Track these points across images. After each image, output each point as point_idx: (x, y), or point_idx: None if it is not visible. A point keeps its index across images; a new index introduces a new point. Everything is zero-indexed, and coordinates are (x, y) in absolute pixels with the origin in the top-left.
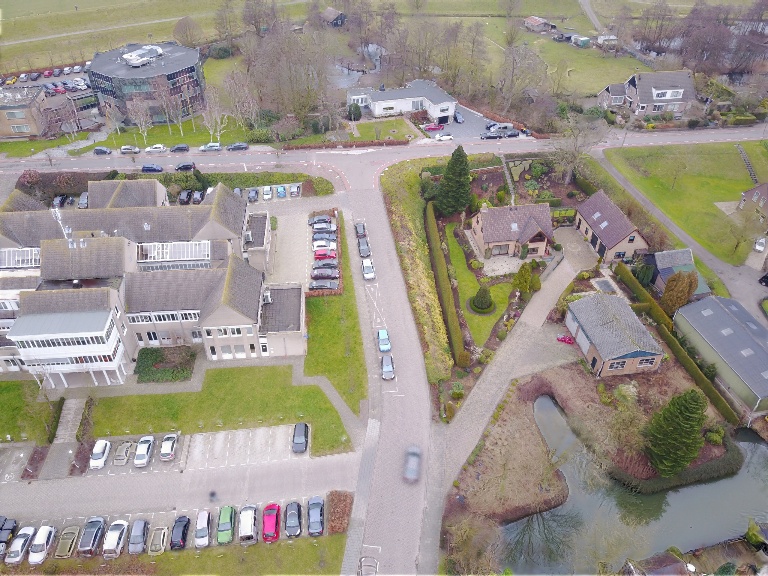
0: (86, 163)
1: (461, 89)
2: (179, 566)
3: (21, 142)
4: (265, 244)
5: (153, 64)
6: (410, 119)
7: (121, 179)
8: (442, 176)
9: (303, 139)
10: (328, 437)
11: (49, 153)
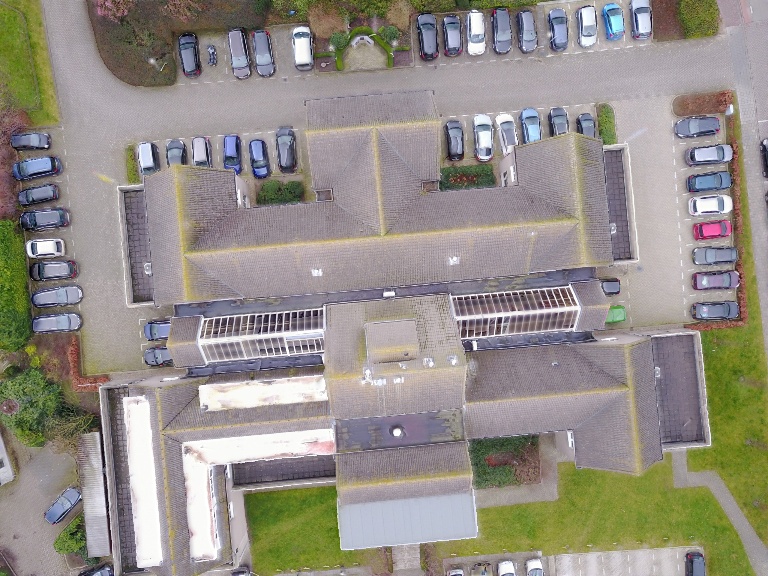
0: None
1: None
2: None
3: None
4: (638, 248)
5: None
6: None
7: None
8: None
9: None
10: (729, 572)
11: None
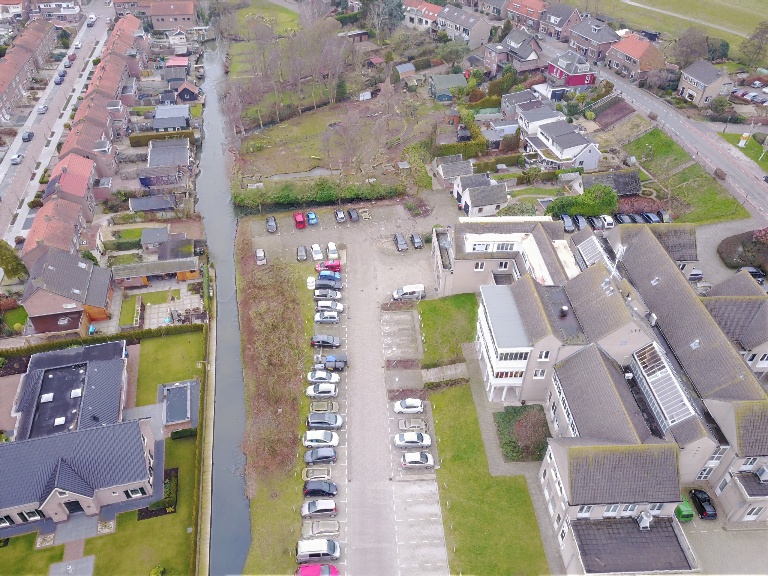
0: None
1: None
2: (289, 496)
3: None
4: (760, 499)
5: None
6: None
7: None
8: None
9: None
10: None
11: None
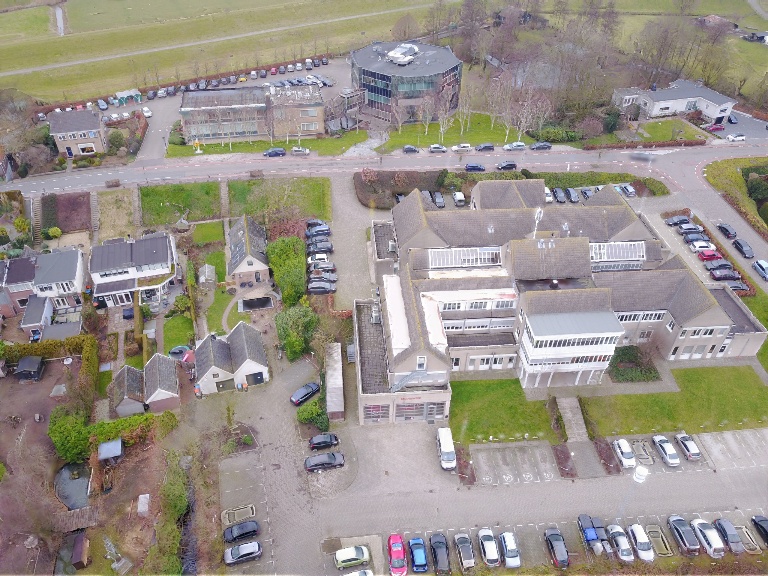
0: (403, 162)
1: (727, 89)
2: None
3: (313, 140)
4: (667, 245)
5: (418, 62)
6: (687, 119)
7: (452, 178)
8: (761, 177)
9: (596, 139)
10: None
11: (357, 151)
